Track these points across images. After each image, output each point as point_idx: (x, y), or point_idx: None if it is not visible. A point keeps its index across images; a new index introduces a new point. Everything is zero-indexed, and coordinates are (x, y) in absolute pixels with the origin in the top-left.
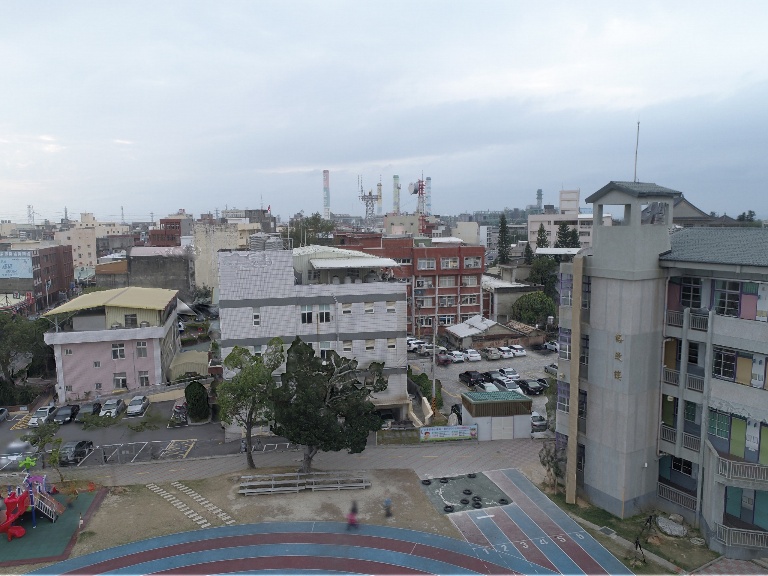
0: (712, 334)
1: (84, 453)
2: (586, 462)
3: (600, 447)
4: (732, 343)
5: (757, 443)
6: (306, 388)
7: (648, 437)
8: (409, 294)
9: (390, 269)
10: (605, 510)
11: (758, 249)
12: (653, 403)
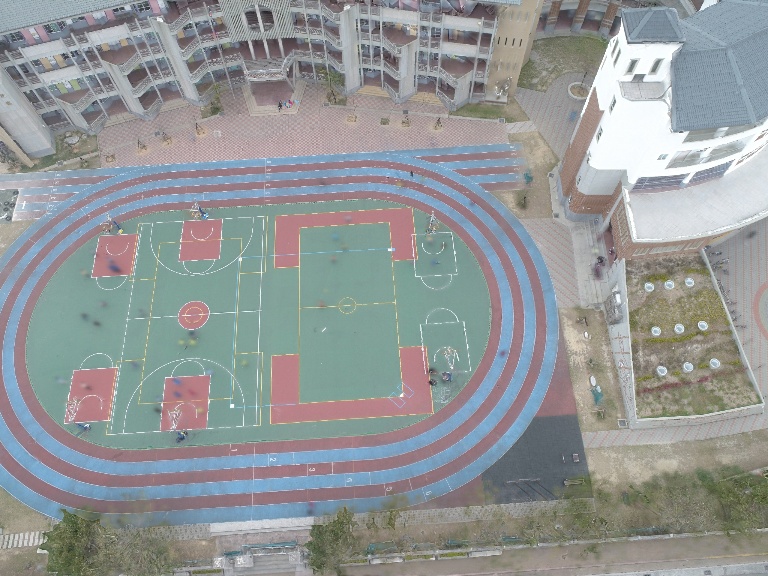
0: (27, 58)
1: None
2: (21, 145)
3: (24, 136)
4: (39, 57)
5: (69, 84)
6: None
7: (34, 114)
8: None
9: None
10: (46, 156)
11: (12, 8)
12: (24, 100)
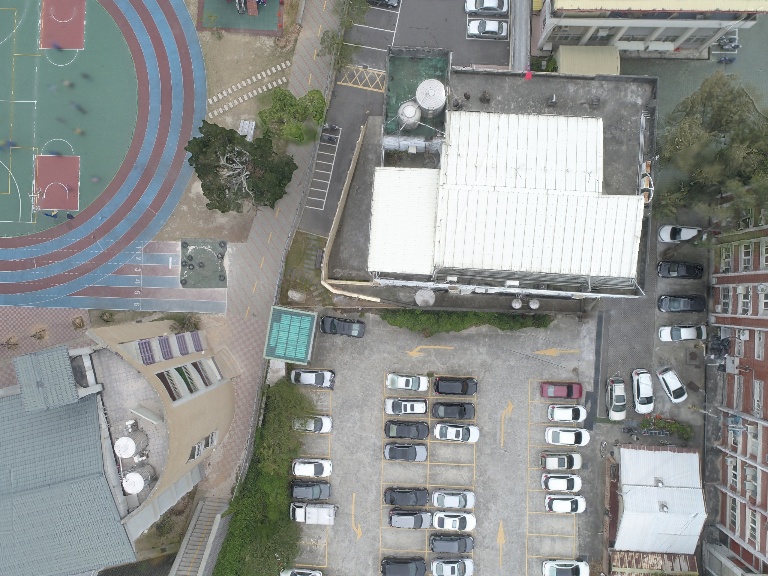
0: None
1: (376, 4)
2: None
3: None
4: None
5: None
6: (209, 147)
7: None
8: (766, 415)
9: (433, 276)
10: None
11: (7, 432)
12: None
